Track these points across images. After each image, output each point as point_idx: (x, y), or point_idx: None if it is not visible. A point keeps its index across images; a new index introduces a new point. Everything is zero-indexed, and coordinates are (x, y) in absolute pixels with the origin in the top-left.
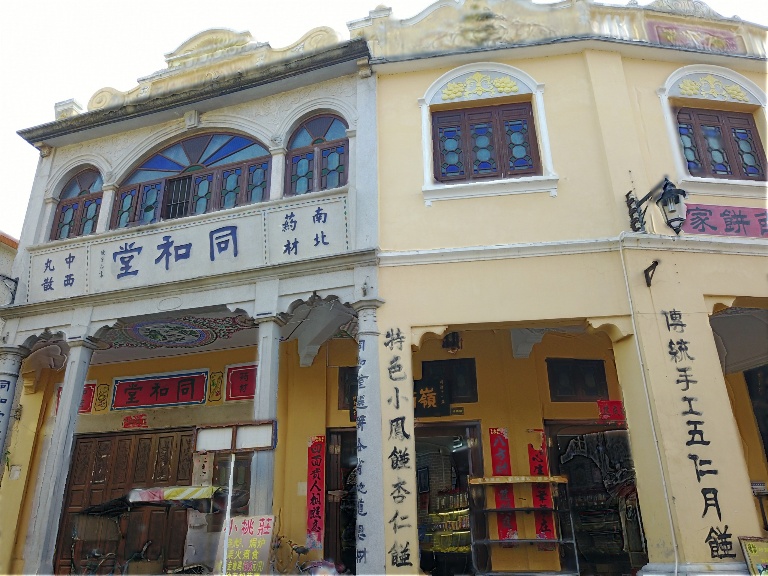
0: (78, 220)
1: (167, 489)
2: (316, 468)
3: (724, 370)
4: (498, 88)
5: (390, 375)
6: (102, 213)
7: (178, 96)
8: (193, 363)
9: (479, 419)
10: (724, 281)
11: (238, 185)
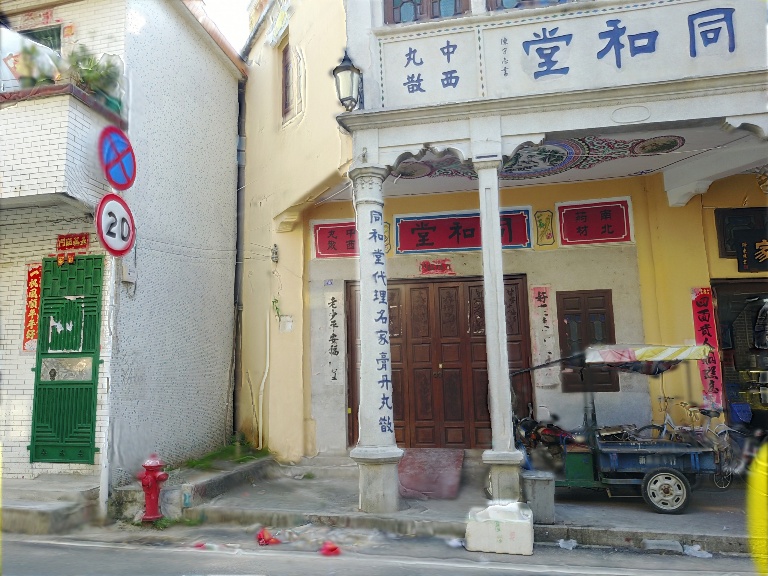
0: None
1: (635, 348)
2: (705, 324)
3: None
4: None
5: None
6: None
7: None
8: (506, 199)
9: None
10: None
11: None
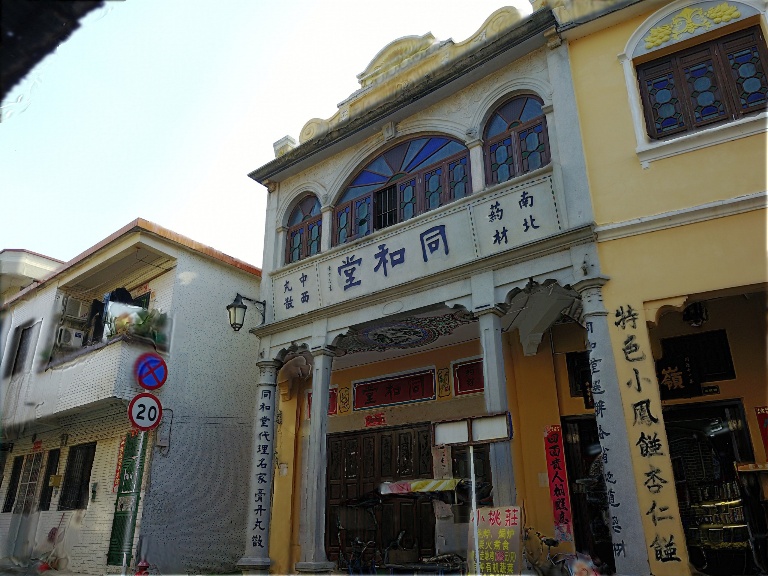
0: (305, 243)
1: (413, 482)
2: (555, 458)
3: None
4: (714, 19)
5: (626, 356)
6: (324, 233)
7: (374, 112)
8: (420, 362)
9: (740, 398)
10: None
11: (440, 185)
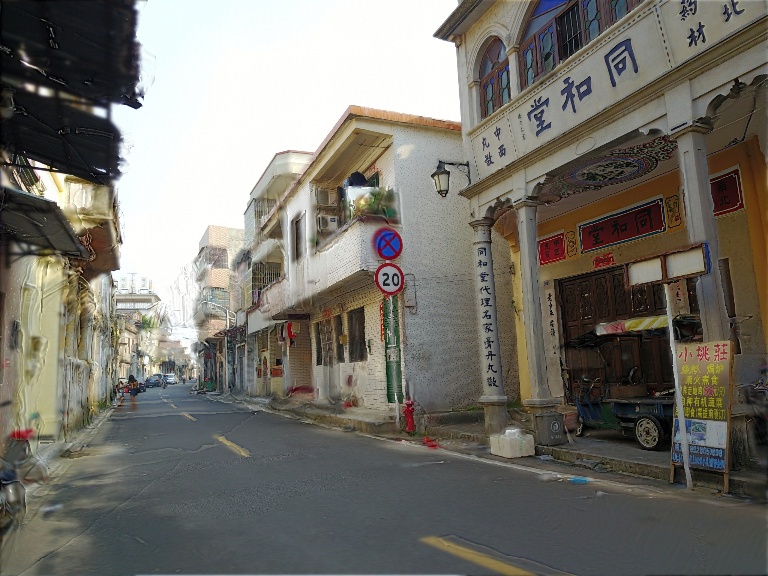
0: (497, 93)
1: (627, 321)
2: None
3: None
4: None
5: None
6: (512, 78)
7: None
8: (645, 193)
9: None
10: None
11: None
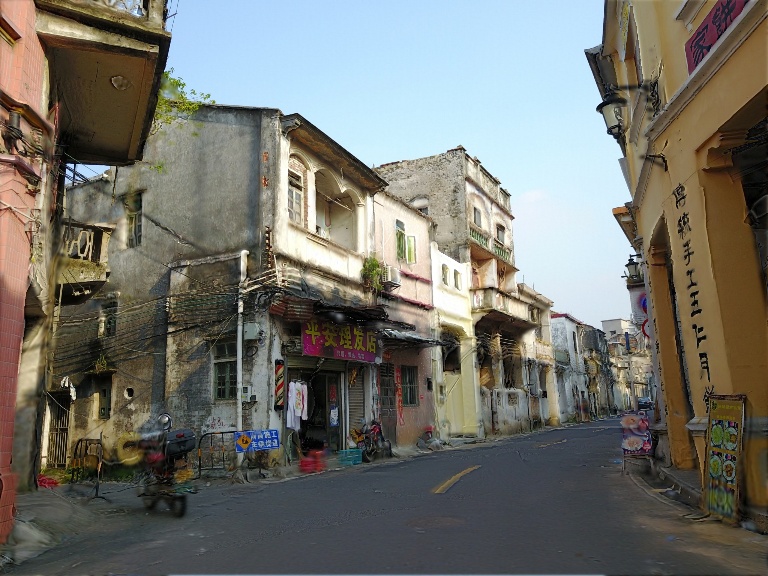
0: None
1: None
2: None
3: (713, 228)
4: None
5: None
6: None
7: None
8: None
9: None
10: (706, 121)
11: None
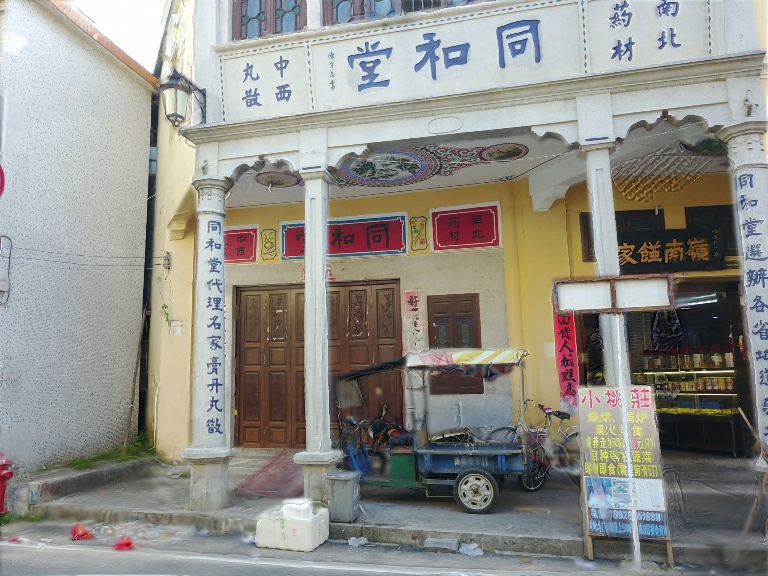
0: (271, 12)
1: (454, 352)
2: (564, 327)
3: None
4: None
5: None
6: (311, 2)
7: None
8: (384, 206)
9: None
10: None
11: None
